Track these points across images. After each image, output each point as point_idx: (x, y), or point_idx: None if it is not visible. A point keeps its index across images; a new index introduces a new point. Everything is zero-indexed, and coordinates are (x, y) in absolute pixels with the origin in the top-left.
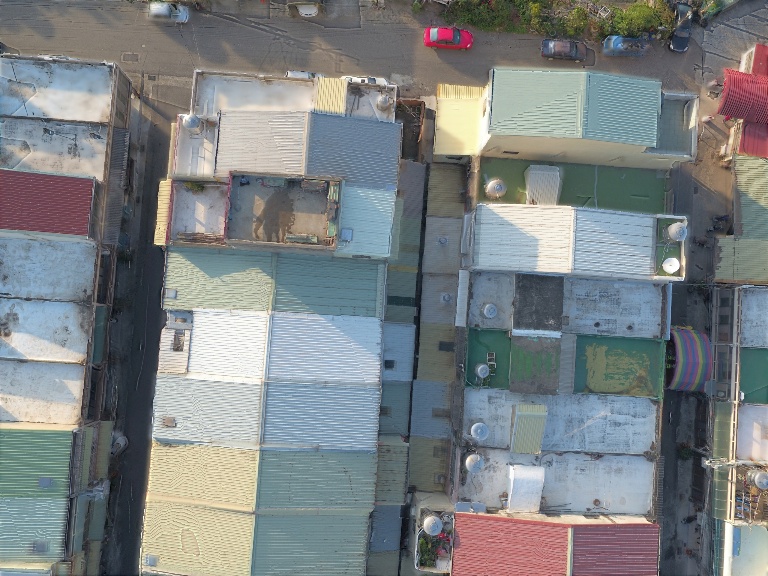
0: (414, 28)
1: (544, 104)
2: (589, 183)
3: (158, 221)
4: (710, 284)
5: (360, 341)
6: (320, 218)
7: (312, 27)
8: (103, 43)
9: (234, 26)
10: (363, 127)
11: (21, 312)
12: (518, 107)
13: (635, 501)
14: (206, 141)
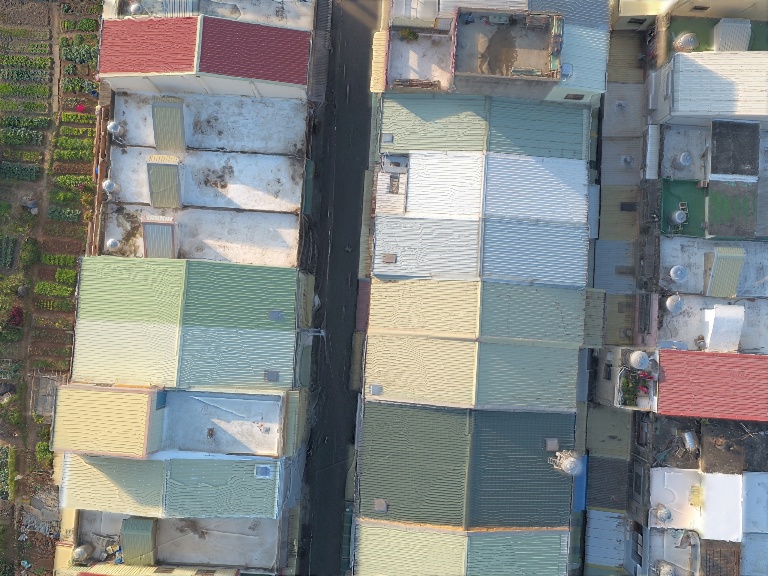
0: None
1: None
2: None
3: (373, 70)
4: None
5: (568, 182)
6: (542, 54)
7: None
8: None
9: None
10: None
11: (236, 165)
12: None
13: None
14: None
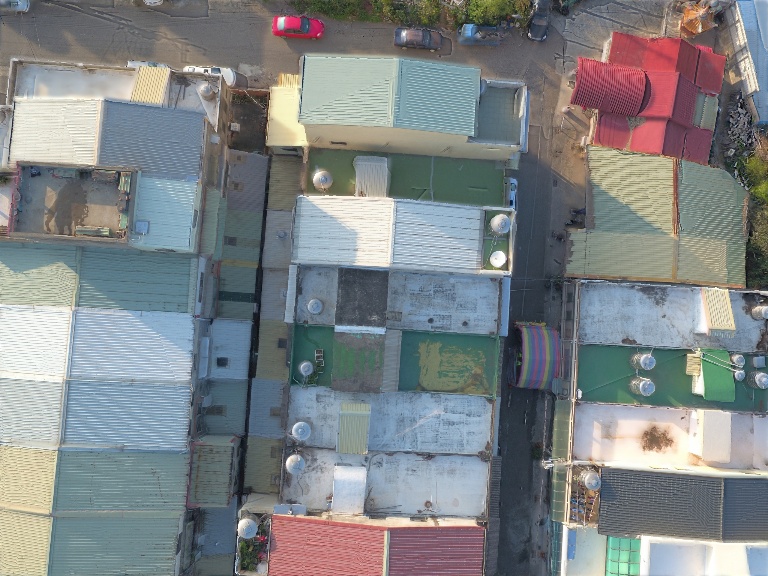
0: (264, 17)
1: (355, 92)
2: (425, 175)
3: None
4: (559, 279)
5: (170, 338)
6: (115, 210)
7: (158, 16)
8: None
9: (77, 15)
10: (162, 116)
11: None
12: (328, 95)
13: (469, 503)
14: None
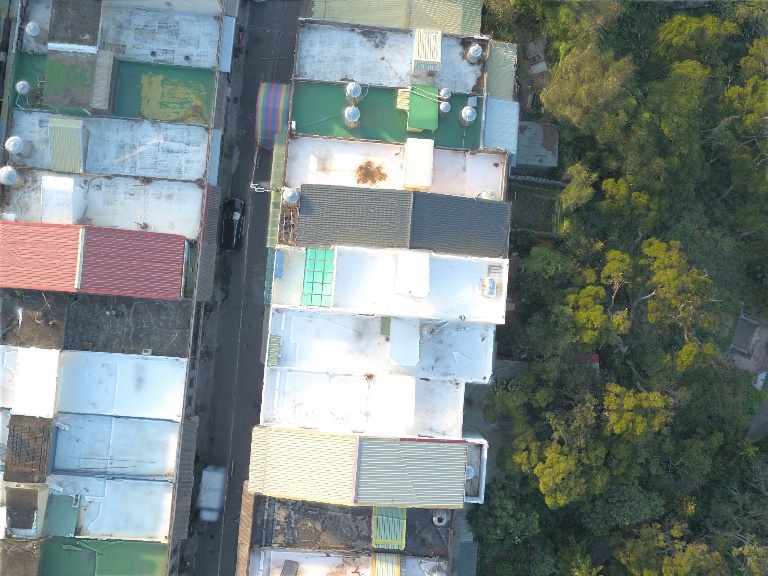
0: None
1: None
2: None
3: None
4: None
5: None
6: None
7: None
8: None
9: None
10: None
11: None
12: None
13: (184, 226)
14: None
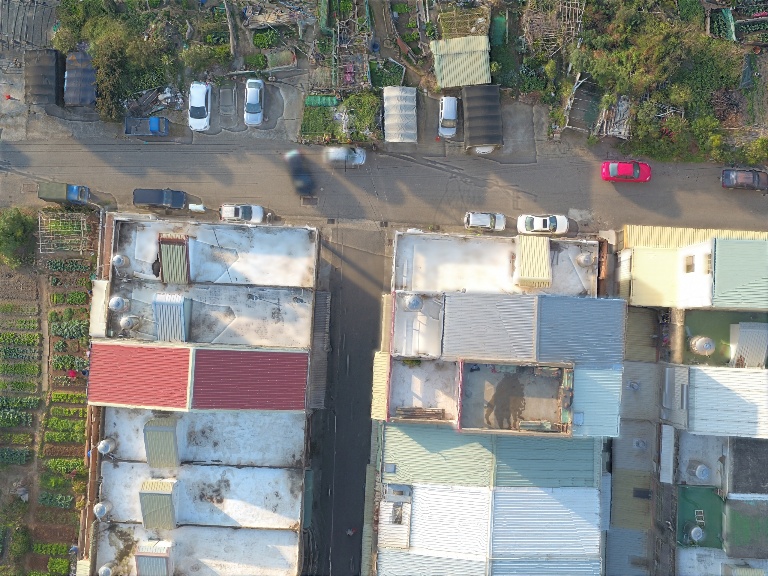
0: (590, 161)
1: None
2: None
3: (374, 395)
4: None
5: (579, 512)
6: (551, 402)
7: (488, 164)
8: (282, 188)
9: (411, 166)
10: (590, 307)
11: (232, 479)
12: (743, 278)
13: None
14: (420, 313)
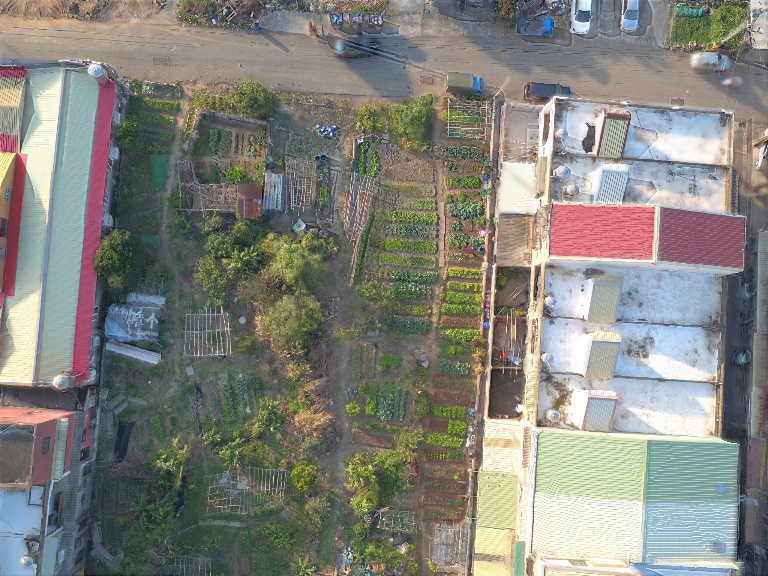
0: None
1: None
2: None
3: None
4: None
5: None
6: None
7: None
8: (652, 89)
9: (765, 74)
10: None
11: (656, 336)
12: None
13: None
14: None
